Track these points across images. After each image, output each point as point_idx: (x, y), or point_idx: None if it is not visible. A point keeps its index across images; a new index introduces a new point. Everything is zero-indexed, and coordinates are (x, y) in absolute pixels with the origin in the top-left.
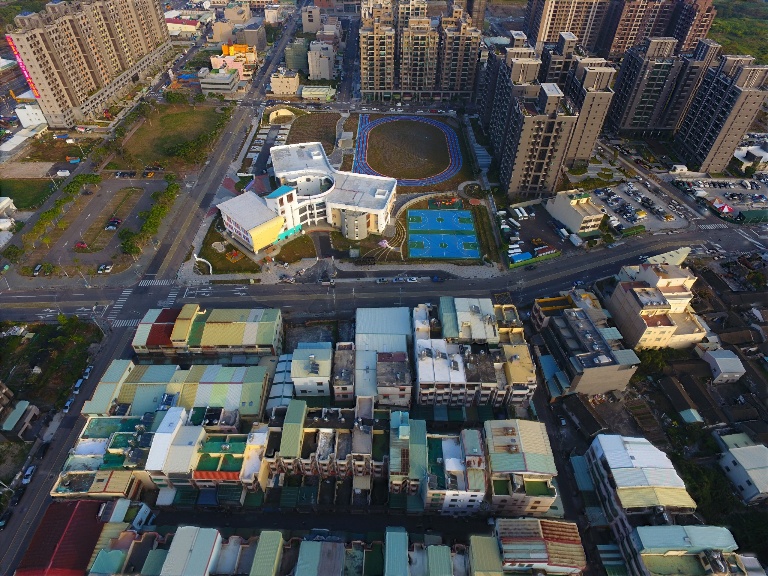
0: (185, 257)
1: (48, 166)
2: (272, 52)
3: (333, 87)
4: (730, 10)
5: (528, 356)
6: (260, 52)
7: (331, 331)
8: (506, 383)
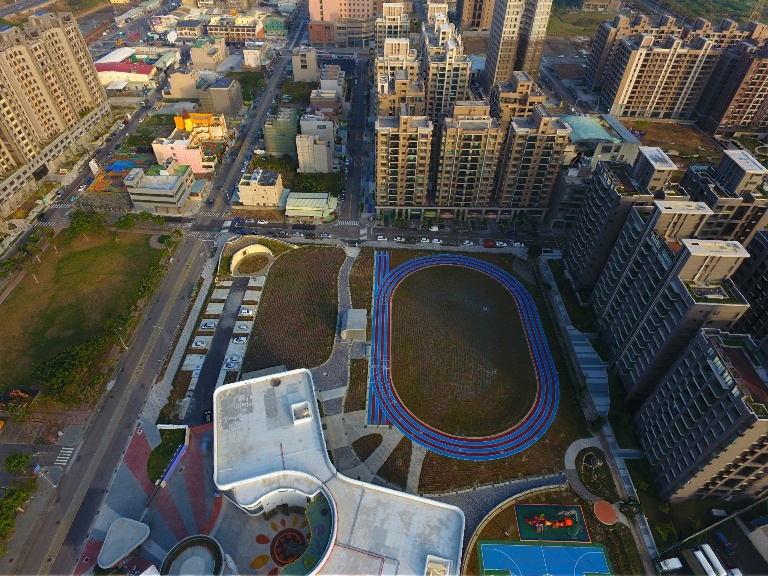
0: None
1: None
2: (249, 117)
3: (333, 188)
4: None
5: None
6: (232, 118)
7: None
8: None
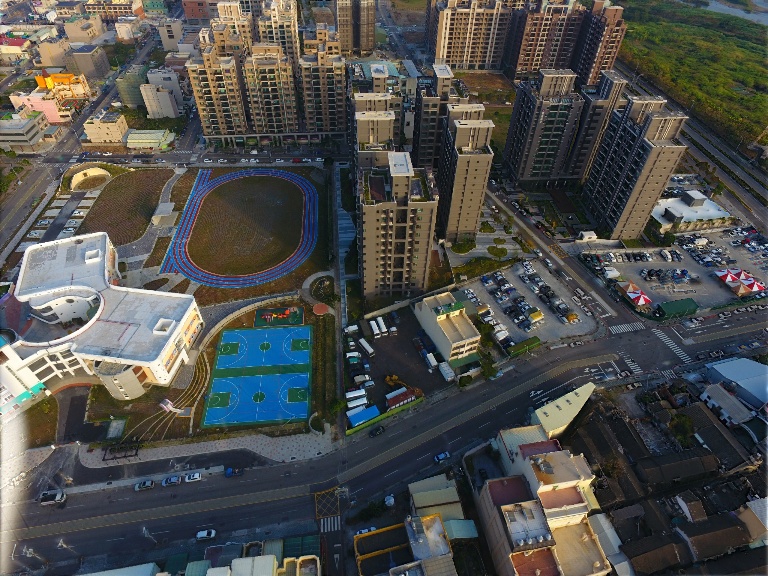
0: None
1: None
2: None
3: (177, 129)
4: (647, 13)
5: None
6: (97, 80)
7: None
8: None
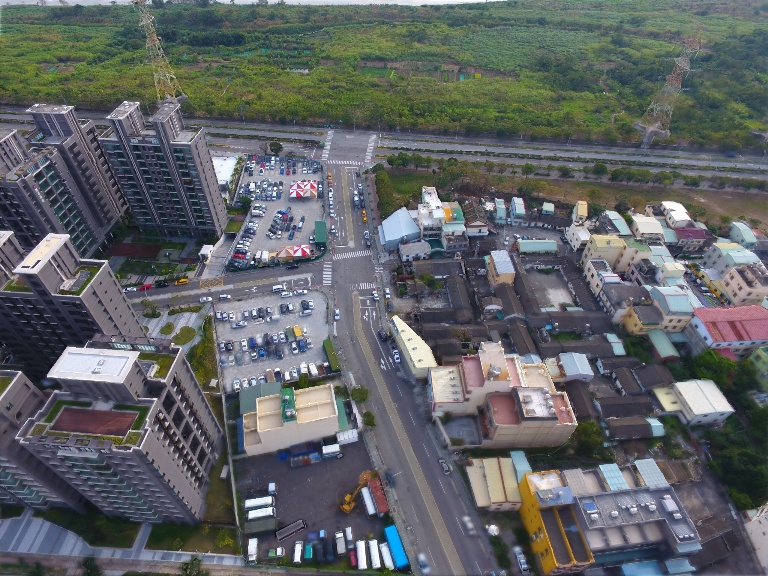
0: None
1: None
2: None
3: None
4: None
5: None
6: None
7: None
8: None
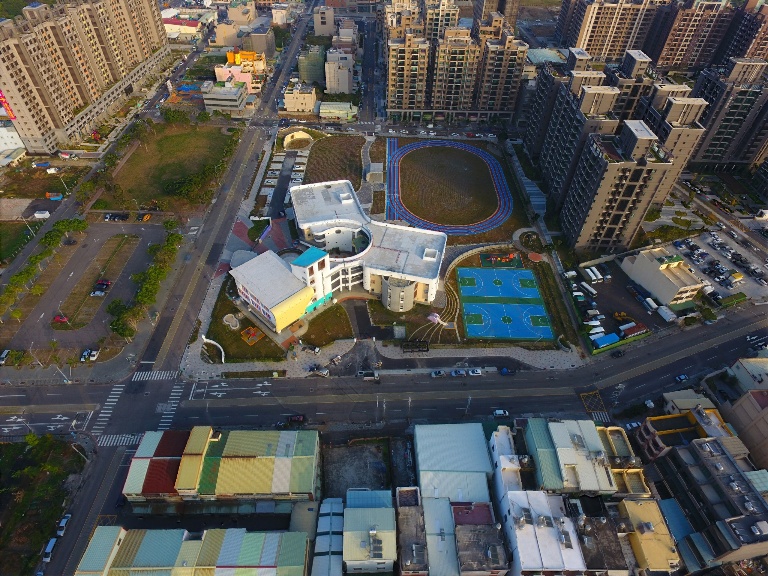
0: (190, 337)
1: (24, 204)
2: (282, 59)
3: (353, 103)
4: None
5: (661, 521)
6: (269, 59)
7: (381, 454)
8: (635, 563)
